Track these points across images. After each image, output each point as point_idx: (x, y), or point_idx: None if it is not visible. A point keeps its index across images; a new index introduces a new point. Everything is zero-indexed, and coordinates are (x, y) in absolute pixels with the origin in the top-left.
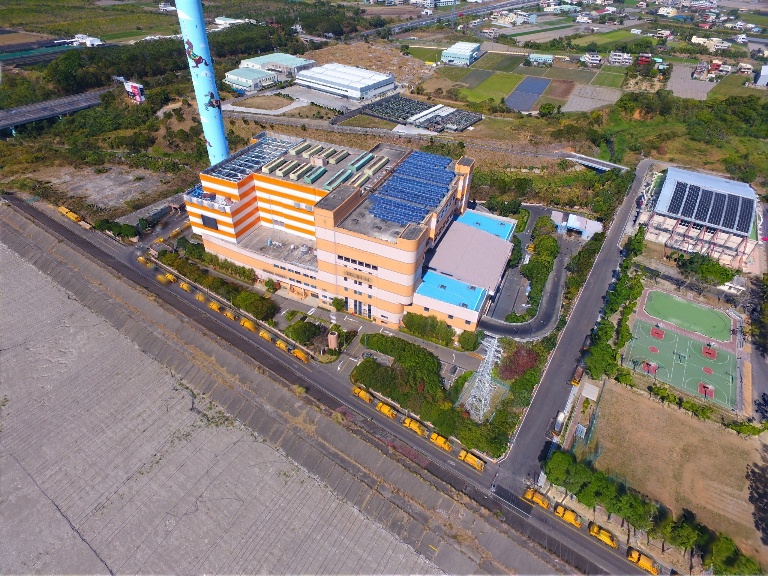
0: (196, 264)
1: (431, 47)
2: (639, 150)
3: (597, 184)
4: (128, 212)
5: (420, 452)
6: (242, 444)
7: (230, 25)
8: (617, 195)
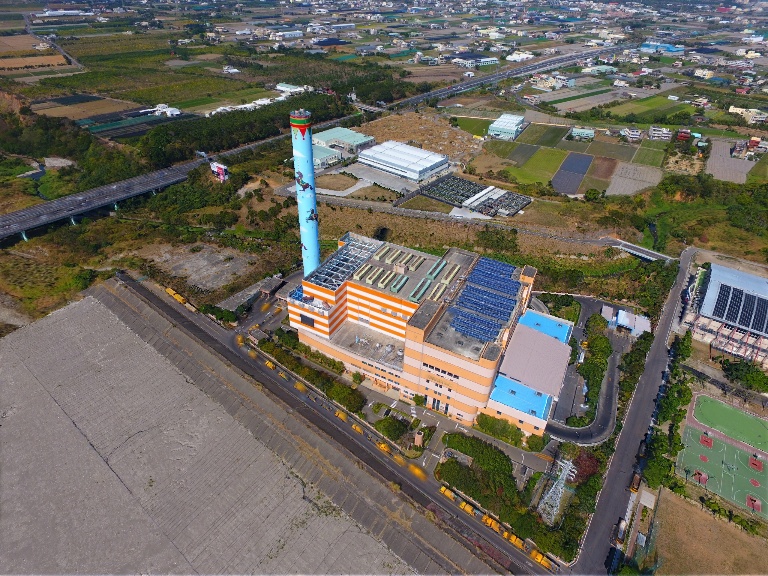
0: (289, 351)
1: (477, 117)
2: (682, 239)
3: (643, 277)
4: (225, 295)
5: (502, 552)
6: (350, 534)
7: (291, 93)
8: (662, 288)
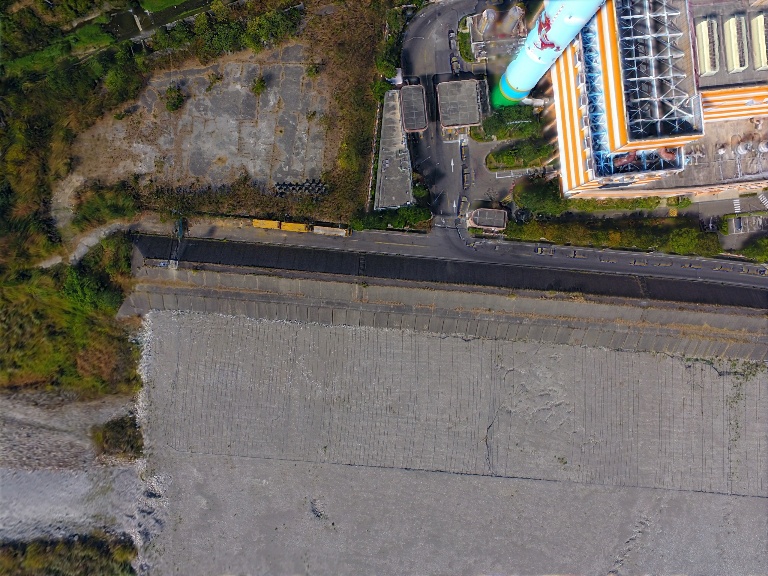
0: (547, 212)
1: None
2: None
3: None
4: (357, 175)
5: None
6: None
7: None
8: None
